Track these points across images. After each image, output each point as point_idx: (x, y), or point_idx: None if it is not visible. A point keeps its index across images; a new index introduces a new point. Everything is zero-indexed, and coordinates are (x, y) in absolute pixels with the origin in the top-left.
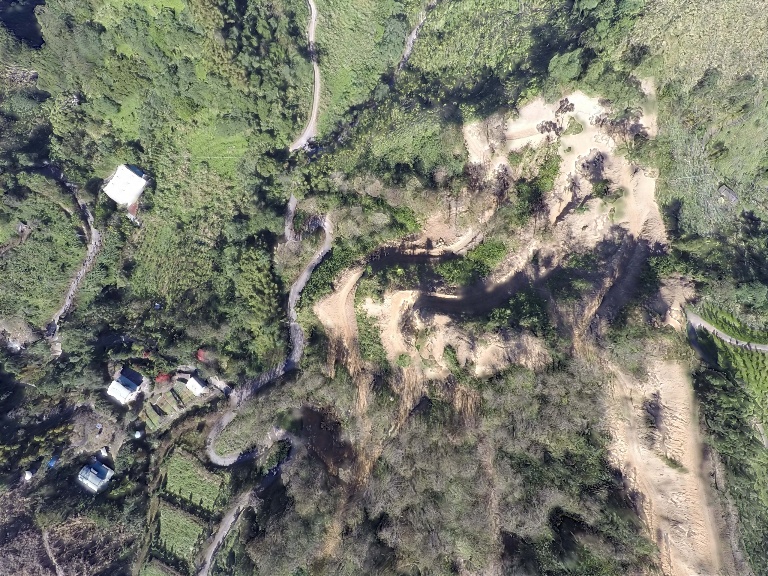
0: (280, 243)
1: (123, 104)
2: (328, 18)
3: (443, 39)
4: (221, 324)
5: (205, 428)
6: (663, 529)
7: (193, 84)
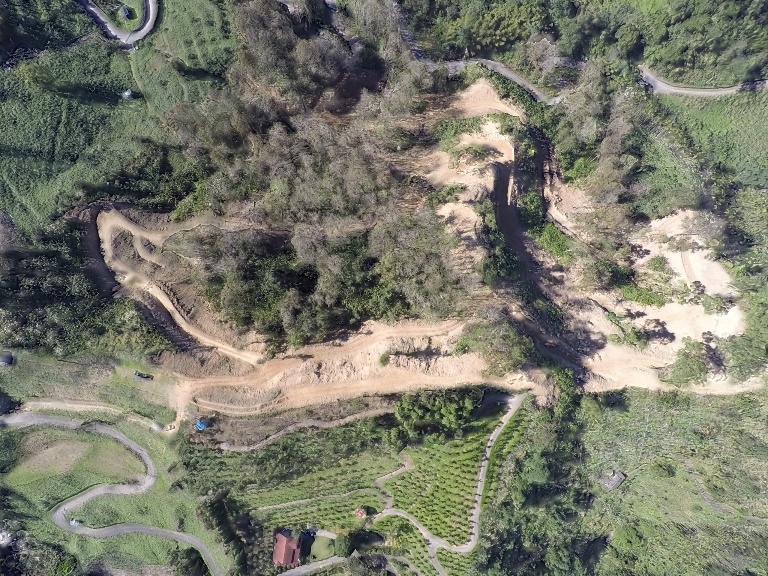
0: None
1: None
2: None
3: None
4: None
5: None
6: (317, 354)
7: None
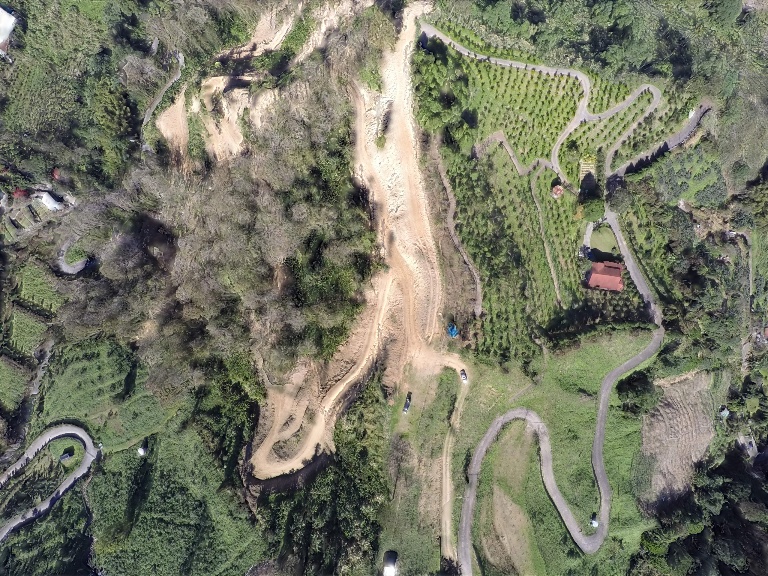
0: None
1: None
2: None
3: None
4: None
5: (59, 241)
6: (381, 216)
7: None
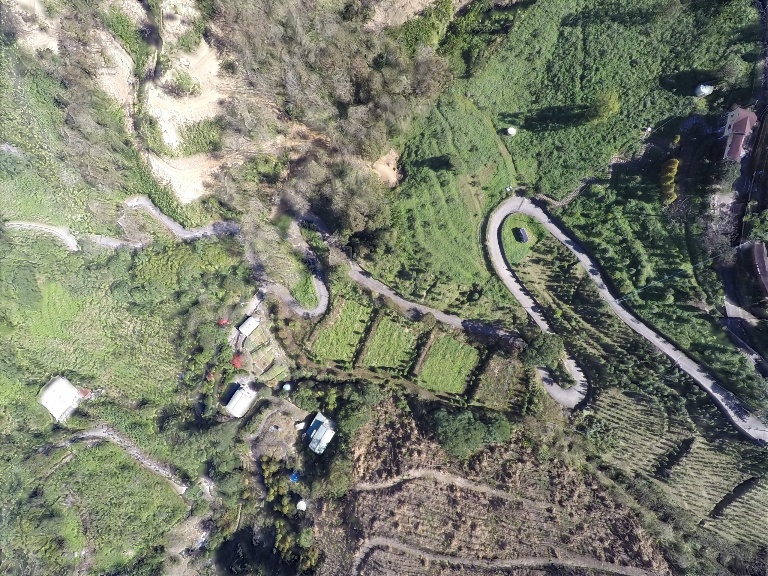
0: None
1: None
2: None
3: None
4: None
5: (293, 319)
6: None
7: None
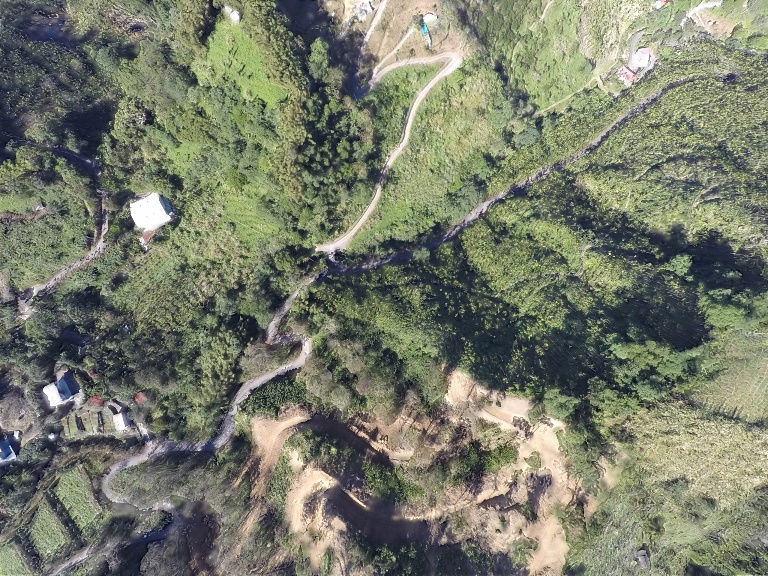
0: (260, 332)
1: (184, 143)
2: (415, 152)
3: (503, 239)
4: (171, 378)
5: (111, 459)
6: None
7: (252, 168)
